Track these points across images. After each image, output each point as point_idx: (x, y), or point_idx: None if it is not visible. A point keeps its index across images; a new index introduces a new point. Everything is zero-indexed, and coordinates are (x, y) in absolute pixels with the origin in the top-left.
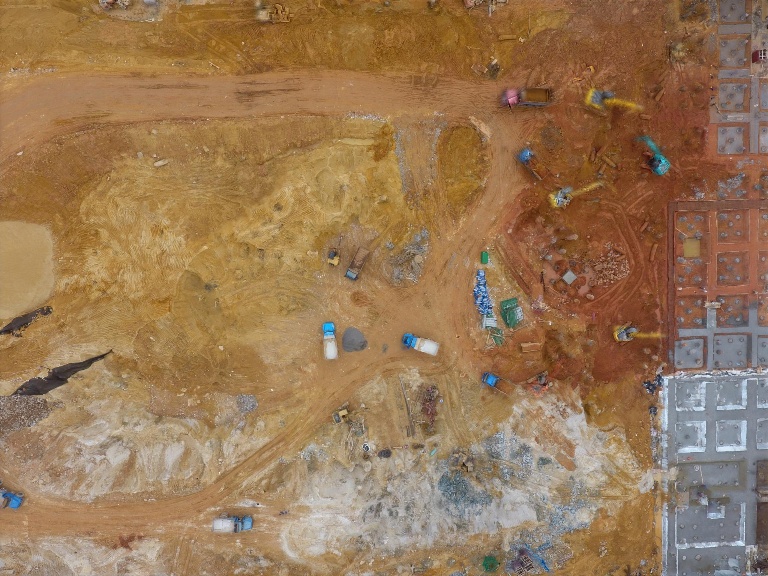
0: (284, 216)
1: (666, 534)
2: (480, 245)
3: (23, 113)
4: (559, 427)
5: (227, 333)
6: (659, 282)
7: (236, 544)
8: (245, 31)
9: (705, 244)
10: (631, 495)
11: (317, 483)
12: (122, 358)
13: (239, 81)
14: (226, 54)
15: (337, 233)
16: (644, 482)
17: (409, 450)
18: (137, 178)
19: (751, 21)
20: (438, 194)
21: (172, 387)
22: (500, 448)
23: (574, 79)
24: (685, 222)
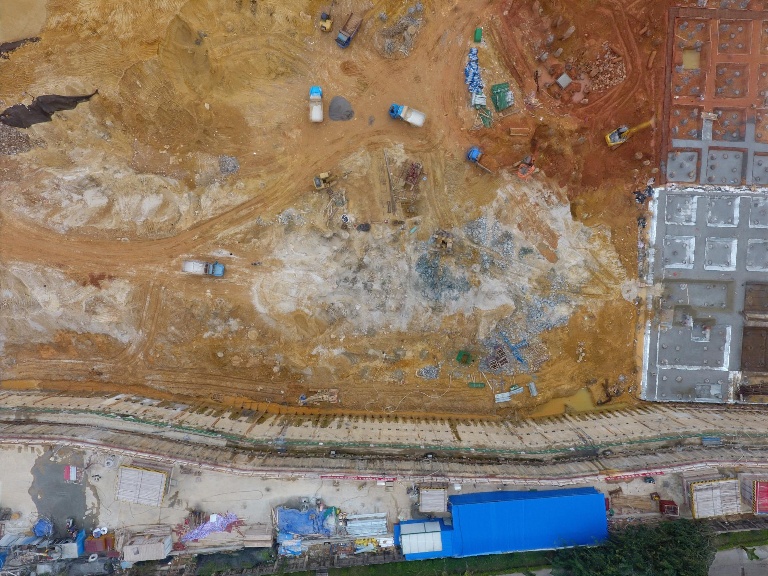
0: None
1: (647, 353)
2: (475, 23)
3: None
4: (543, 215)
5: (214, 93)
6: (656, 91)
7: (206, 294)
8: None
9: (705, 55)
10: (613, 295)
11: (292, 242)
12: (107, 100)
13: None
14: None
15: (331, 0)
16: (627, 289)
17: (389, 226)
18: None
19: None
20: None
21: (155, 143)
22: (481, 234)
23: None
24: (686, 30)
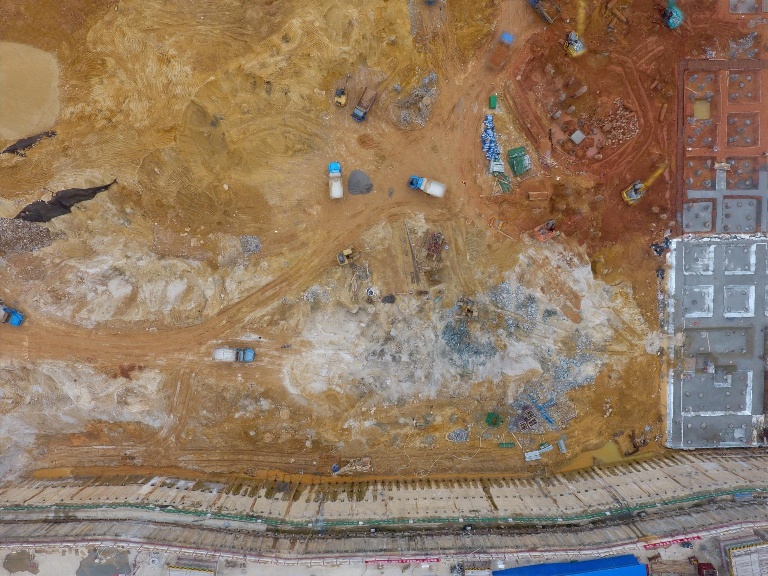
0: (292, 47)
1: (671, 401)
2: (488, 90)
3: None
4: (565, 278)
5: (232, 173)
6: (668, 143)
7: (237, 378)
8: None
9: (715, 105)
10: (637, 351)
11: (320, 321)
12: (126, 189)
13: None
14: None
15: (345, 74)
16: (650, 342)
17: (413, 296)
18: (145, 9)
19: None
20: (447, 37)
21: (175, 226)
22: (505, 298)
23: None
24: (695, 82)
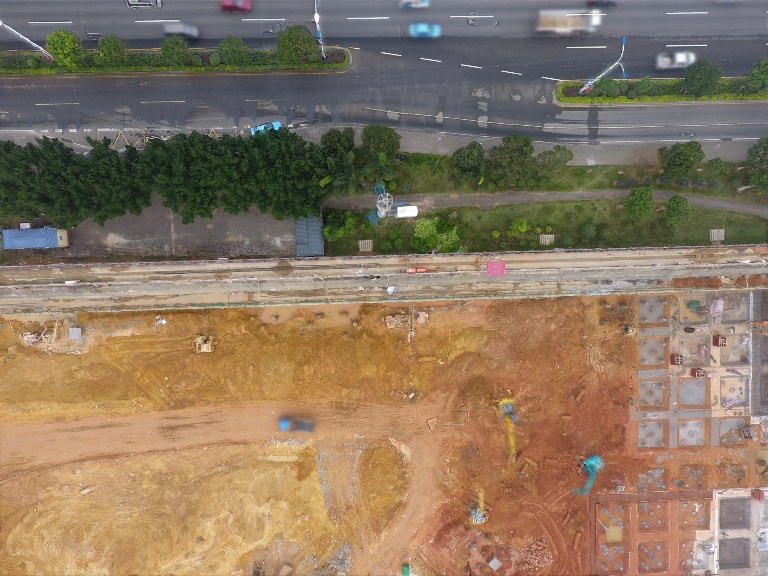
0: (206, 549)
1: None
2: (402, 557)
3: None
4: None
5: None
6: (583, 568)
7: None
8: (169, 364)
9: (627, 532)
10: None
11: None
12: None
13: (162, 416)
14: (150, 389)
15: (262, 548)
16: None
17: None
18: (63, 508)
19: (669, 324)
20: (360, 509)
21: None
22: None
23: (492, 401)
24: None
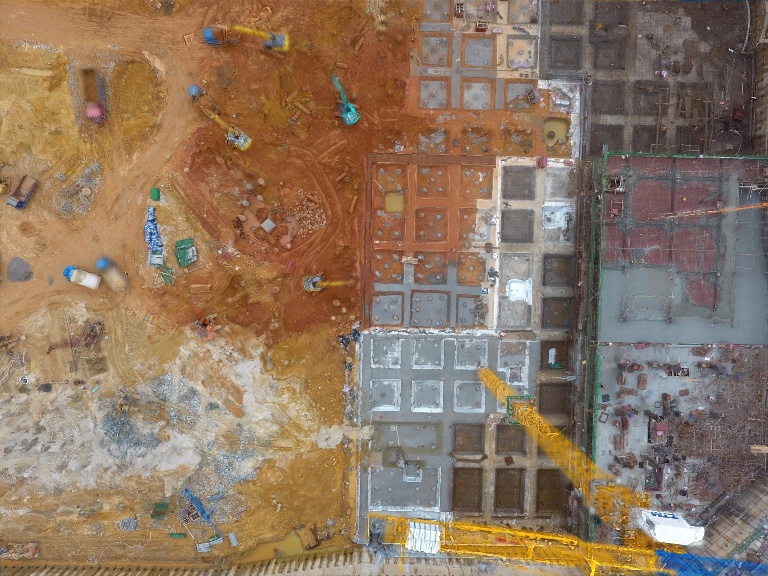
0: None
1: (358, 495)
2: (153, 182)
3: None
4: (227, 372)
5: None
6: (359, 235)
7: None
8: None
9: (406, 198)
10: (303, 447)
11: None
12: None
13: None
14: None
15: (8, 162)
16: (326, 437)
17: (70, 386)
18: None
19: None
20: (113, 128)
21: None
22: (167, 390)
23: (251, 19)
24: (386, 175)
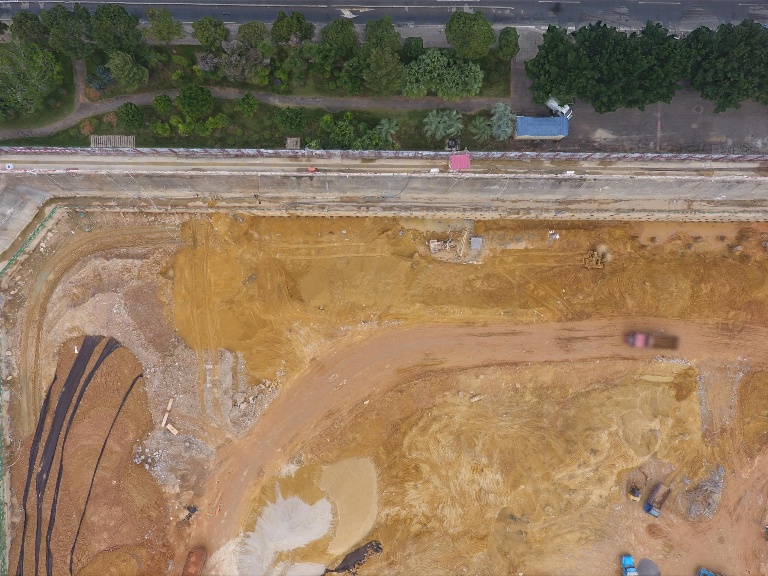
0: (600, 460)
1: None
2: None
3: (370, 364)
4: None
5: (526, 559)
6: None
7: None
8: (564, 278)
9: None
10: None
11: None
12: None
13: (559, 327)
14: (547, 301)
15: (636, 467)
16: None
17: None
18: (455, 414)
19: None
20: (735, 432)
21: None
22: None
23: None
24: None
